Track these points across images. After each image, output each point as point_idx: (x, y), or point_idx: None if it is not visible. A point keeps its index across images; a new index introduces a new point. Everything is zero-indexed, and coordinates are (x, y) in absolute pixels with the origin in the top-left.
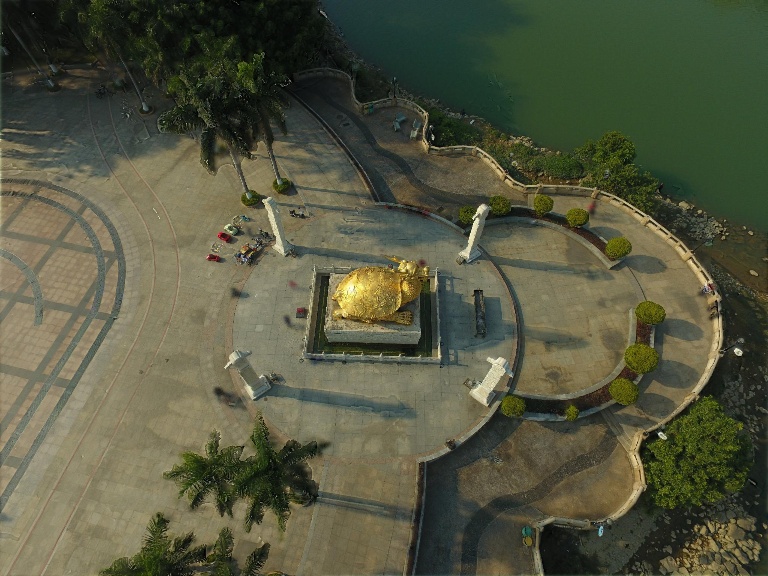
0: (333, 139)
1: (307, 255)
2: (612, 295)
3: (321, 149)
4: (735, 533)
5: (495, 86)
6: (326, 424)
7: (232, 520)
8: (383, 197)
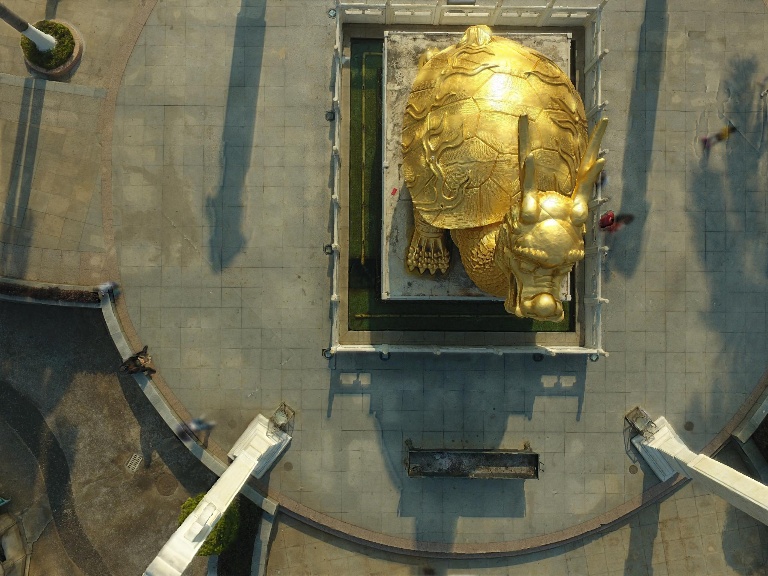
0: None
1: None
2: None
3: None
4: None
5: None
6: (184, 84)
7: None
8: None
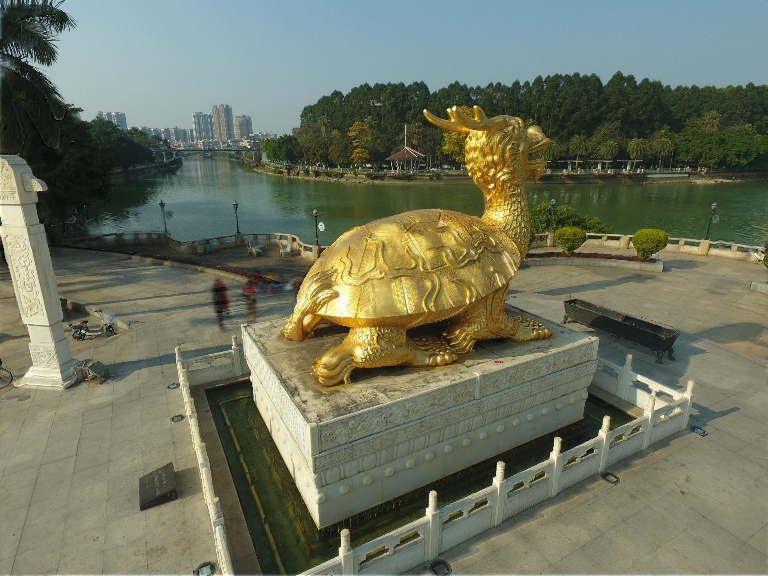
0: (154, 260)
1: (142, 370)
2: (708, 285)
3: (133, 271)
4: None
5: None
6: None
7: None
8: None
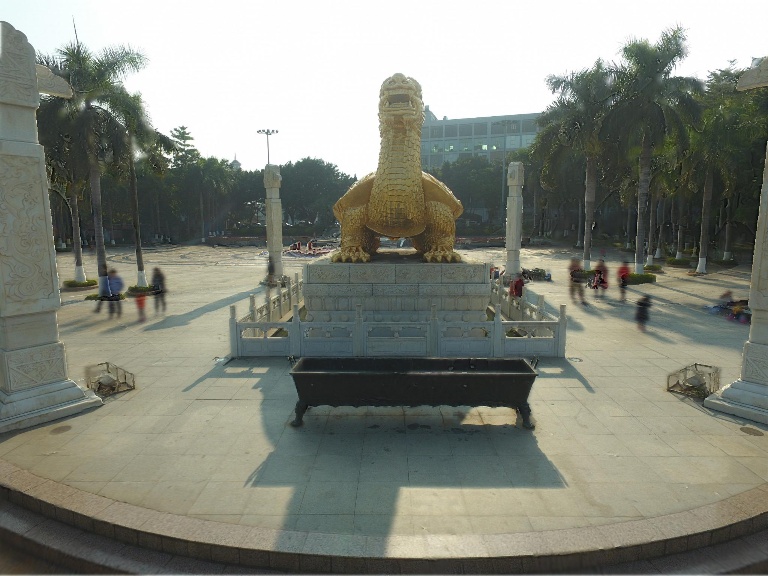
0: None
1: None
2: None
3: None
4: None
5: None
6: None
7: (122, 290)
8: None
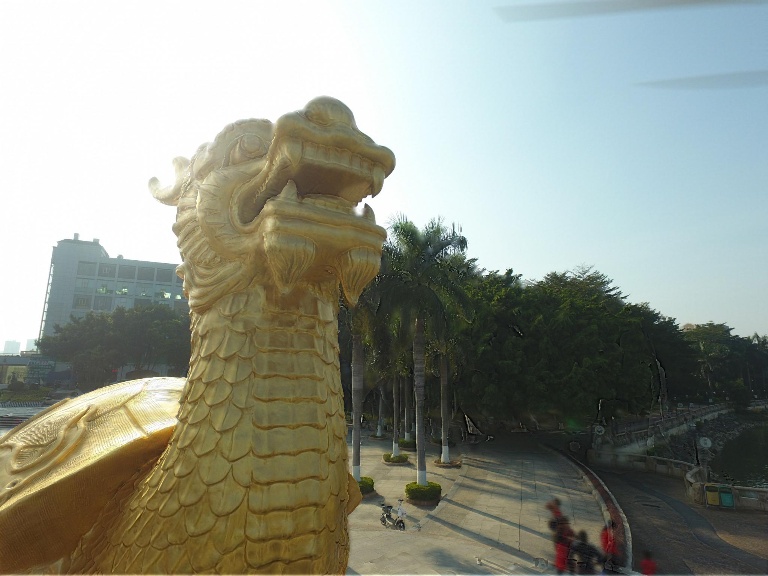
0: (590, 485)
1: None
2: None
3: (553, 489)
4: None
5: None
6: None
7: None
8: None
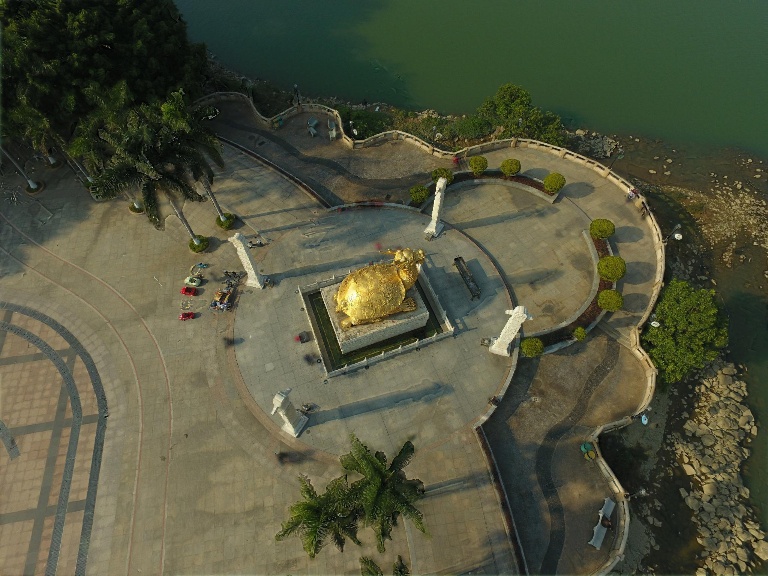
0: (257, 161)
1: (284, 280)
2: (564, 225)
3: (249, 174)
4: (725, 381)
5: (382, 71)
6: (377, 430)
7: (328, 558)
8: (330, 202)
